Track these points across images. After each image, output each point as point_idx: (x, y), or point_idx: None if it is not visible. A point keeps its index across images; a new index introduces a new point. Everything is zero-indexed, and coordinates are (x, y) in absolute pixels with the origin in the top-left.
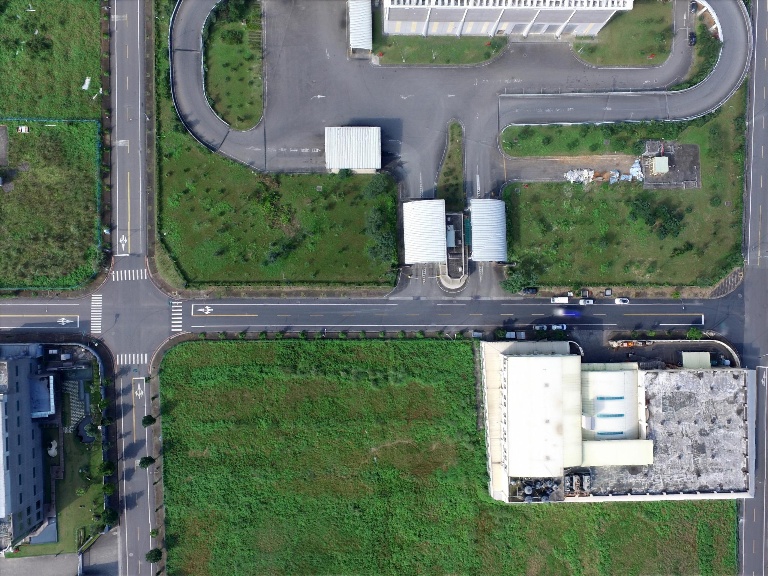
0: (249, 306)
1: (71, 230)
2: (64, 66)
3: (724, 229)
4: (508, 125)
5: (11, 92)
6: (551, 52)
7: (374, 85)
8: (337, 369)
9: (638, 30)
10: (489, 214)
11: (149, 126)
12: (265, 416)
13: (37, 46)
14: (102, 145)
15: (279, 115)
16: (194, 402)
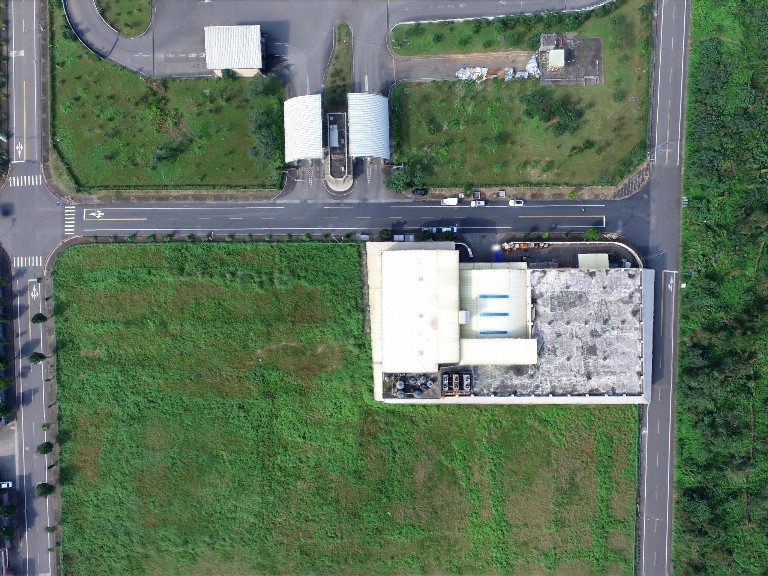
0: (138, 210)
1: None
2: None
3: (628, 126)
4: (397, 23)
5: None
6: None
7: None
8: (223, 271)
9: None
10: (367, 109)
11: (43, 36)
12: (153, 317)
13: None
14: None
15: (167, 21)
16: (86, 303)
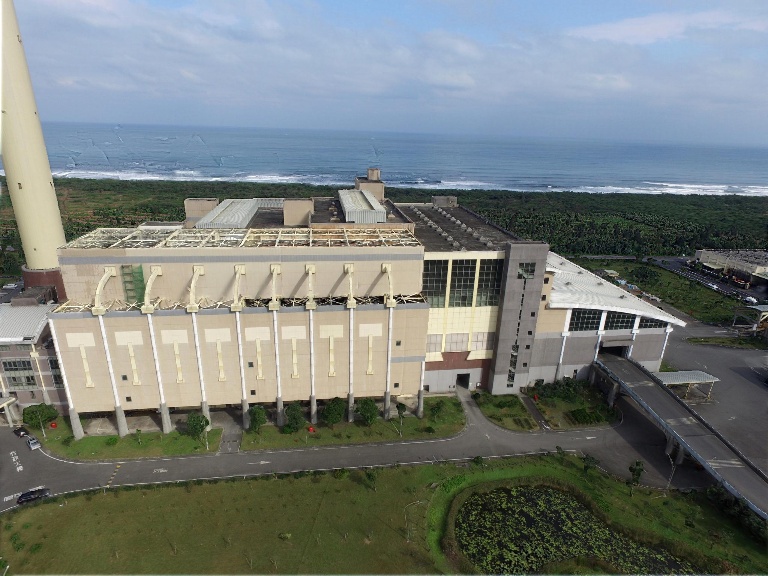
0: None
1: None
2: None
3: None
4: None
5: None
6: None
7: (720, 384)
8: None
9: None
10: None
11: None
12: None
13: None
14: None
15: None
16: None
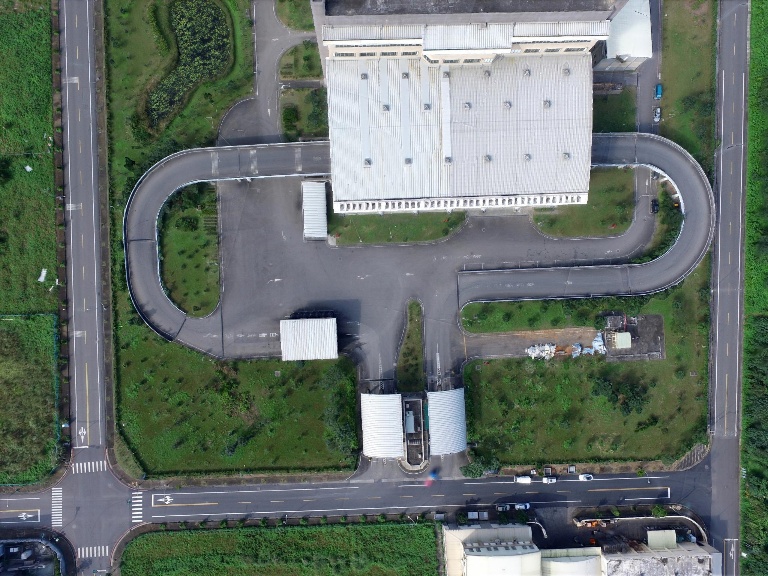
0: (209, 494)
1: (30, 425)
2: (20, 259)
3: (689, 400)
4: (467, 302)
5: None
6: (510, 225)
7: (331, 266)
8: (298, 556)
9: (599, 200)
10: (447, 406)
11: (106, 316)
12: None
13: None
14: (59, 337)
15: (236, 300)
16: None
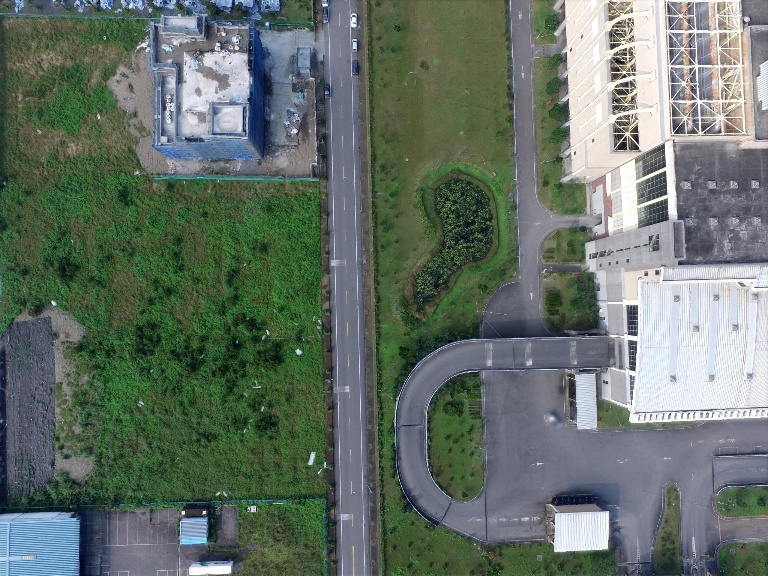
0: None
1: None
2: (290, 443)
3: None
4: (723, 487)
5: (239, 471)
6: None
7: (591, 450)
8: None
9: None
10: None
11: (372, 499)
12: None
13: (266, 427)
14: (327, 520)
15: (499, 484)
16: None
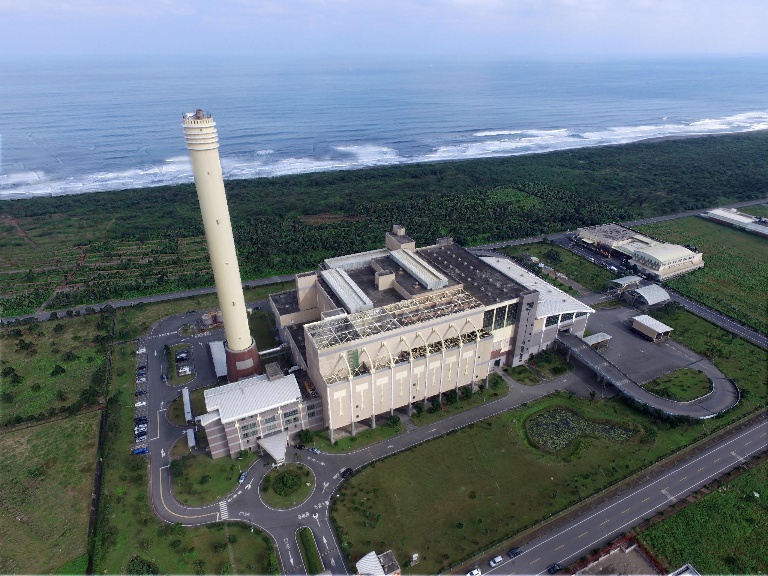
0: (767, 345)
1: None
2: None
3: None
4: None
5: None
6: None
7: None
8: None
9: None
10: None
11: None
12: None
13: None
14: None
15: None
16: None
